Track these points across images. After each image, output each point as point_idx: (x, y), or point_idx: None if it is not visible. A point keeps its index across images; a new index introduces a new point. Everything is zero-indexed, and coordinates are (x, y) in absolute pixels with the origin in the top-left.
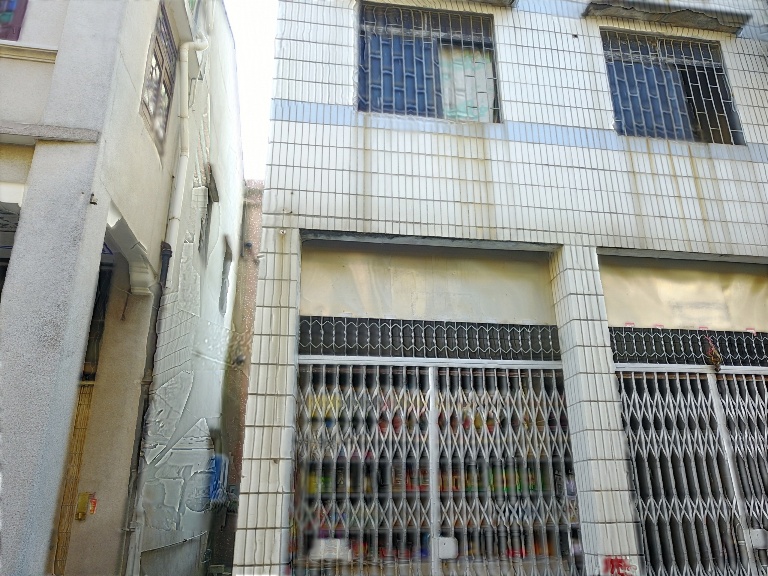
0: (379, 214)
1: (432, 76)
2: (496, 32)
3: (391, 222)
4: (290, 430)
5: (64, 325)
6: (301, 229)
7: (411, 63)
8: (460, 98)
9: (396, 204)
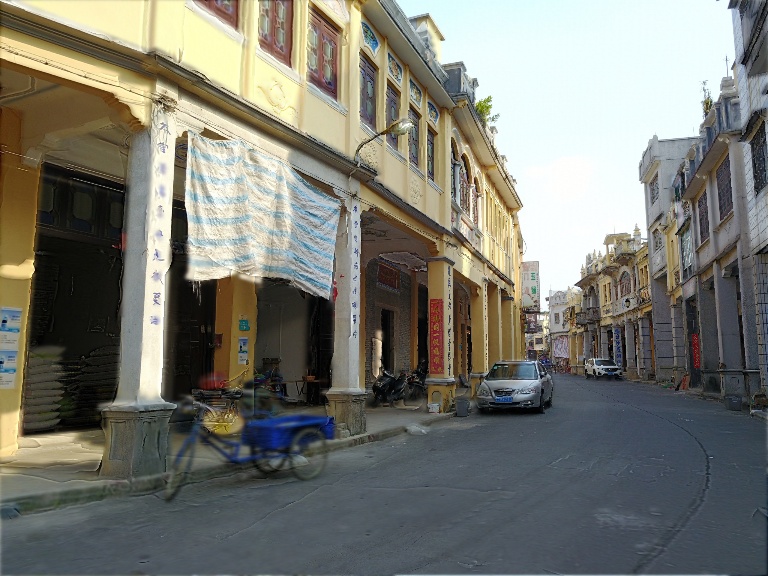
0: (760, 241)
1: (763, 165)
2: (765, 129)
3: None
4: None
5: None
6: (755, 254)
7: (760, 163)
8: (767, 171)
9: (762, 235)
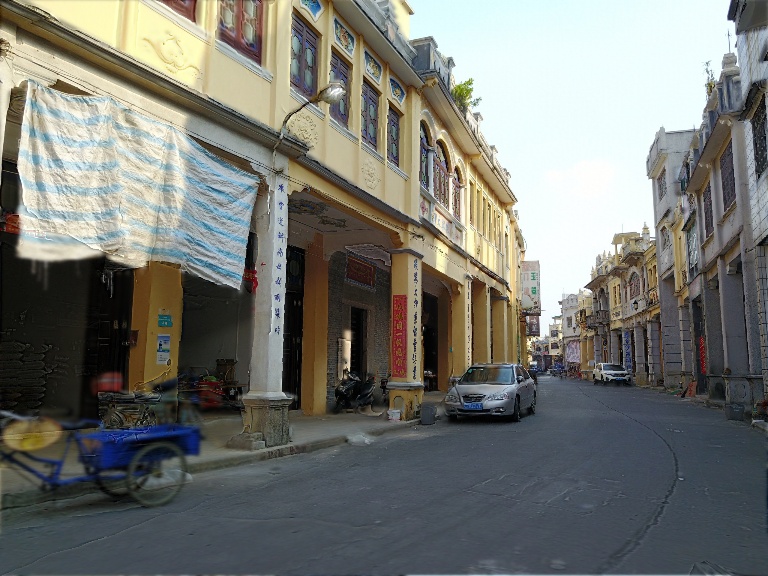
0: None
1: (764, 145)
2: None
3: (763, 233)
4: (762, 325)
5: (748, 297)
6: (757, 245)
7: (761, 142)
8: None
9: None
